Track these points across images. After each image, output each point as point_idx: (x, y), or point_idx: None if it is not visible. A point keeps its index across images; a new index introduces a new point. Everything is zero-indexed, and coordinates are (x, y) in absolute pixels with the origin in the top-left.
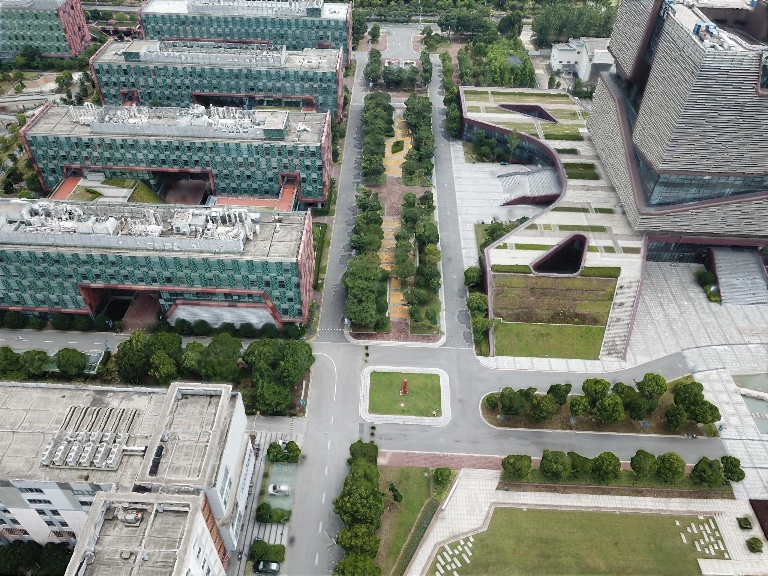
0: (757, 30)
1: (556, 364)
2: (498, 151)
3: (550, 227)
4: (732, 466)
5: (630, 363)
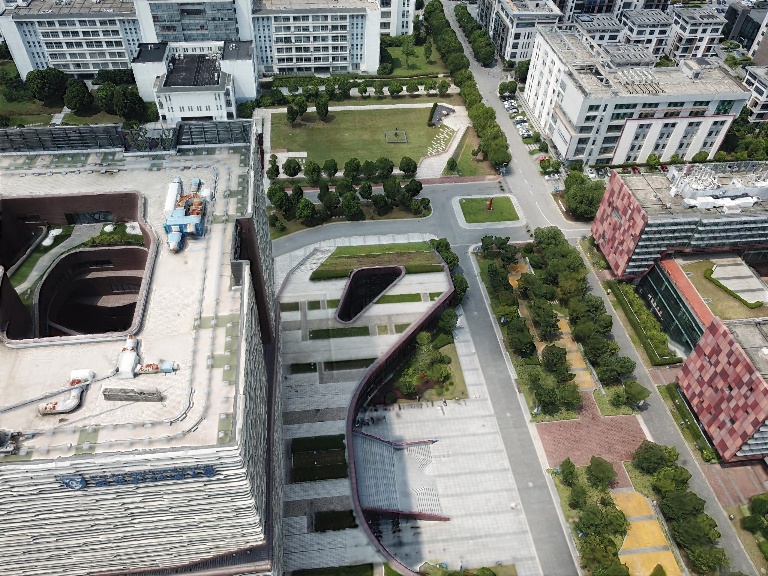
0: (26, 312)
1: (374, 240)
2: (460, 573)
3: (380, 330)
4: (277, 165)
5: (311, 248)
